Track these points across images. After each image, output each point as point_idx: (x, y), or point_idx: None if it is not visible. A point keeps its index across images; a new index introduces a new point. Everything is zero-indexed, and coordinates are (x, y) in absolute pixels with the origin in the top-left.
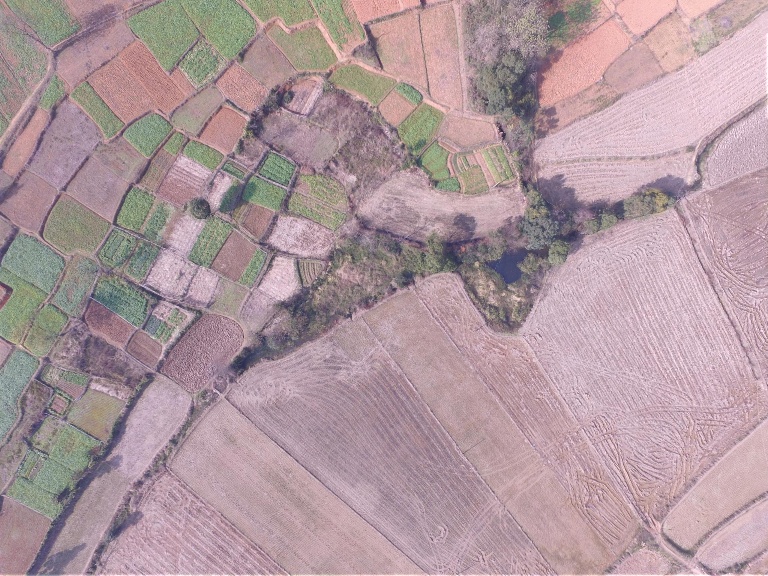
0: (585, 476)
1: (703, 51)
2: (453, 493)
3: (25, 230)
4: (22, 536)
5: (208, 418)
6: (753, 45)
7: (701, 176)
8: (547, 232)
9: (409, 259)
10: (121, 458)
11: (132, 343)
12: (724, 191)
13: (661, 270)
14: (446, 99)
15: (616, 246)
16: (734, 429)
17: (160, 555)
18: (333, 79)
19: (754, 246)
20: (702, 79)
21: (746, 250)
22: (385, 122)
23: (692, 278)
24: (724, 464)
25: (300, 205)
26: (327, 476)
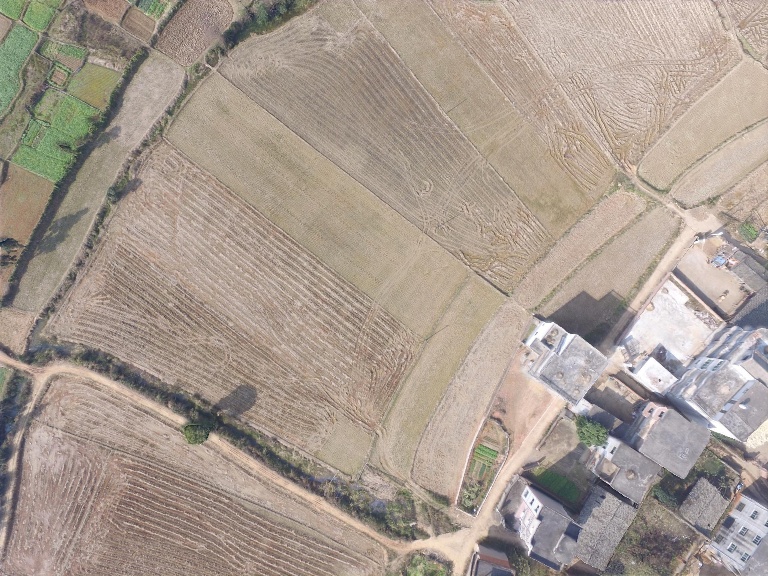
0: (563, 129)
1: None
2: (437, 150)
3: None
4: (27, 199)
5: (201, 91)
6: None
7: None
8: None
9: None
10: (119, 129)
11: (127, 19)
12: None
13: None
14: None
15: None
16: (705, 78)
17: (159, 218)
18: None
19: None
20: None
21: None
22: None
23: None
24: (696, 110)
25: None
26: (316, 139)
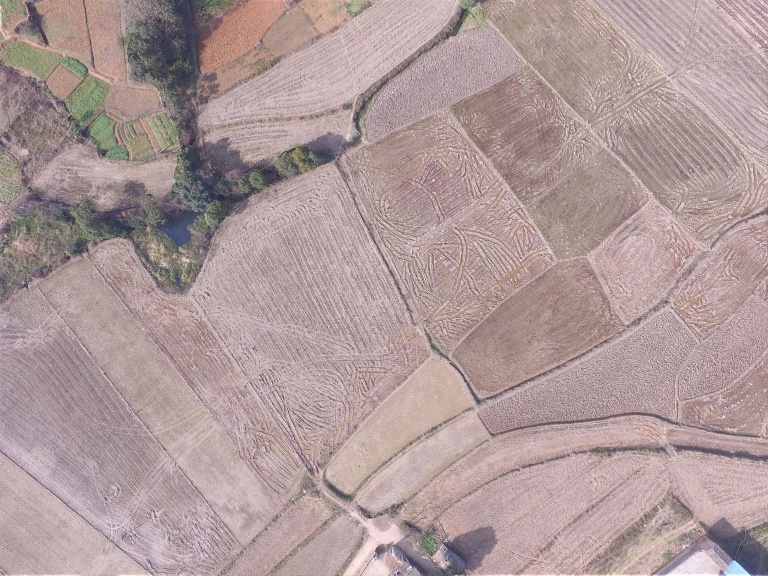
0: (253, 429)
1: (355, 12)
2: (126, 453)
3: None
4: None
5: None
6: (403, 4)
7: (360, 132)
8: (192, 192)
9: None
10: None
11: None
12: (382, 145)
13: (323, 225)
14: (110, 70)
15: (280, 204)
16: (394, 375)
17: None
18: (1, 57)
19: (411, 197)
20: (356, 39)
21: (403, 201)
22: (52, 96)
23: (353, 231)
24: (383, 409)
25: None
26: (4, 443)
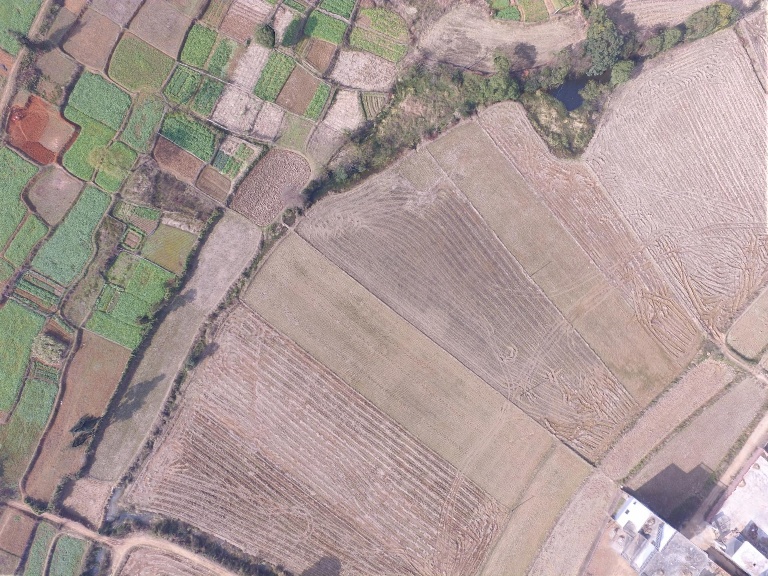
0: (650, 293)
1: None
2: (521, 314)
3: (90, 68)
4: (103, 367)
5: (278, 251)
6: None
7: None
8: (612, 47)
9: (471, 90)
10: (195, 292)
11: (201, 178)
12: None
13: (721, 91)
14: None
15: (676, 69)
16: None
17: (237, 383)
18: None
19: None
20: None
21: None
22: None
23: (752, 98)
24: None
25: (361, 39)
26: (397, 303)
